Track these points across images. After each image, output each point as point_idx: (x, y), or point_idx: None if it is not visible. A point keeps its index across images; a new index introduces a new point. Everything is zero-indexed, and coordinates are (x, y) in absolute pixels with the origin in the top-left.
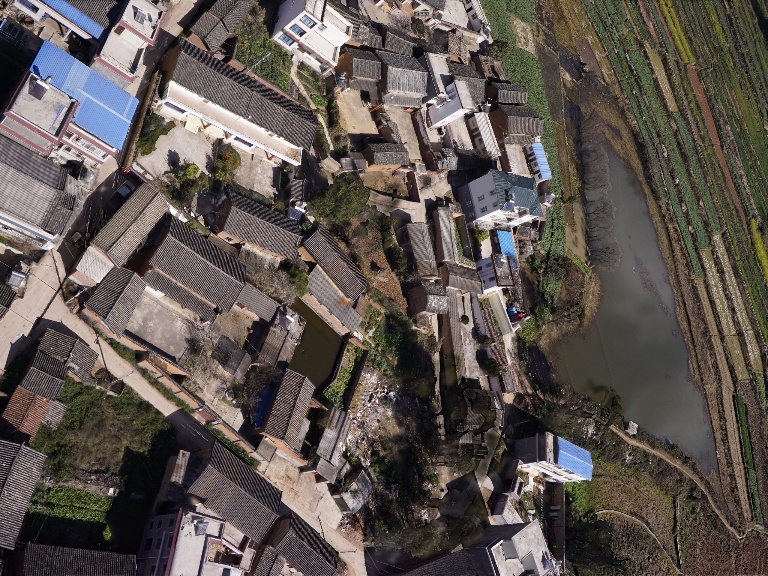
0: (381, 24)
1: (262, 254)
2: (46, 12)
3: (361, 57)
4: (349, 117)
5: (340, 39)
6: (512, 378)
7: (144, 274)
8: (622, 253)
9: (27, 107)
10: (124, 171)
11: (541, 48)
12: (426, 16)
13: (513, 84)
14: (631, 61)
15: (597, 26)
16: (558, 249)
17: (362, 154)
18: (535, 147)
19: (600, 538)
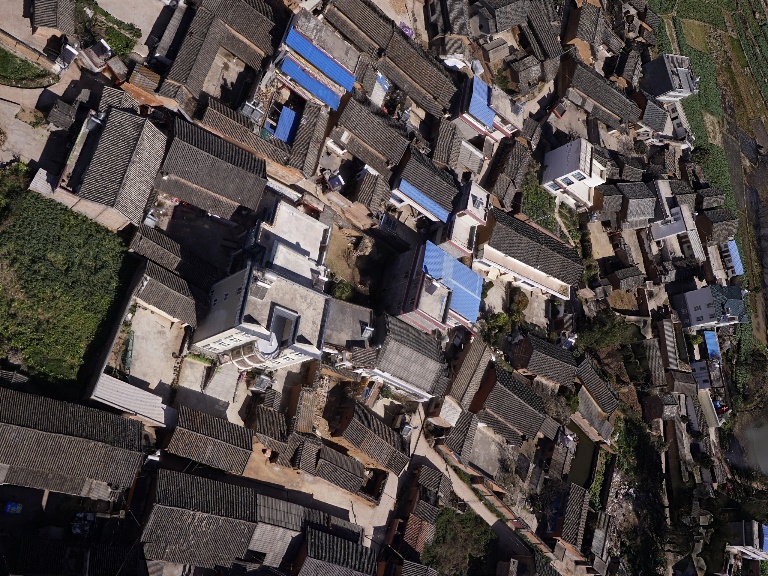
0: (618, 156)
1: (546, 382)
2: (410, 204)
3: (608, 193)
4: (594, 244)
5: (596, 182)
6: (721, 470)
7: (477, 413)
8: None
9: (425, 302)
10: None
11: (726, 138)
12: (647, 137)
13: (713, 188)
14: None
15: None
16: (747, 338)
17: (608, 279)
18: (730, 245)
19: None
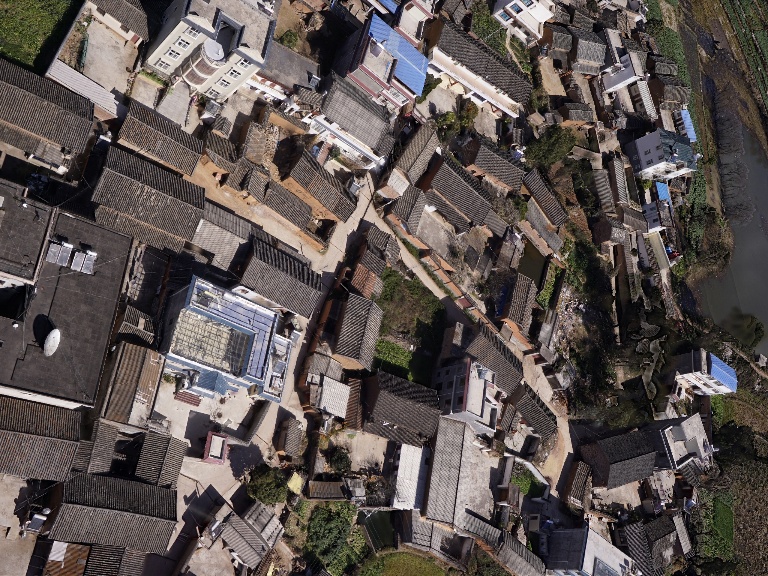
0: (569, 4)
1: (495, 185)
2: None
3: (558, 31)
4: (546, 81)
5: (545, 16)
6: (671, 303)
7: (425, 192)
8: (755, 209)
9: (370, 62)
10: (405, 115)
11: (682, 27)
12: None
13: (666, 58)
14: (757, 40)
15: (727, 8)
16: (700, 203)
17: (558, 111)
18: (683, 113)
19: (744, 439)
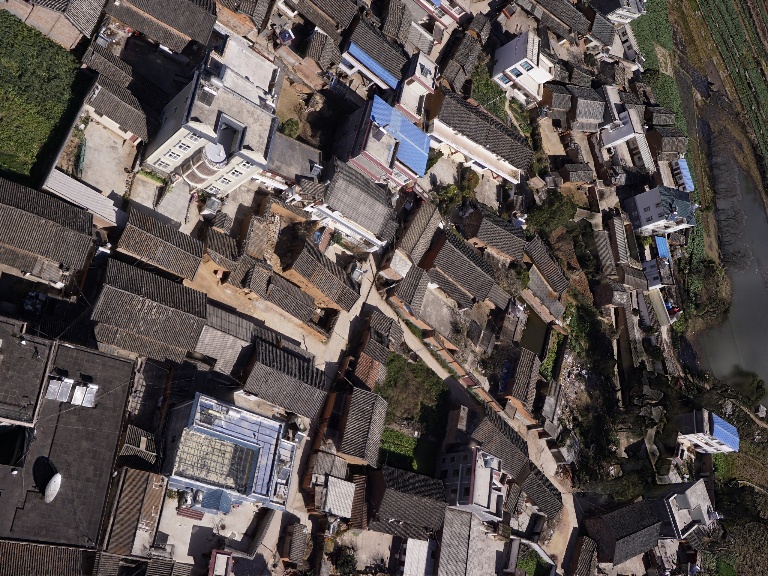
0: (568, 61)
1: (497, 256)
2: (360, 69)
3: (557, 92)
4: (545, 141)
5: (544, 78)
6: (672, 363)
7: (428, 271)
8: (753, 257)
9: (372, 147)
10: (406, 190)
11: (677, 71)
12: (596, 51)
13: (663, 107)
14: (750, 79)
15: (721, 47)
16: (699, 252)
17: (558, 173)
18: (680, 163)
19: (746, 500)
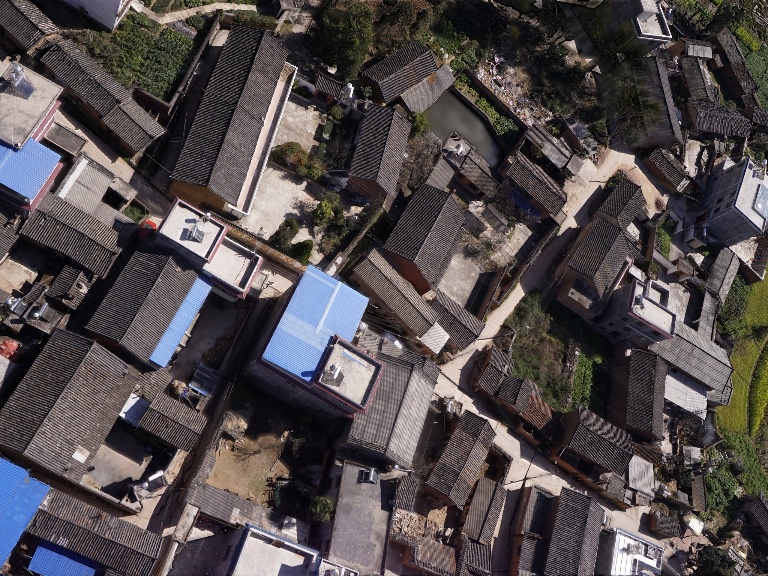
0: None
1: None
2: None
3: None
4: None
5: None
6: None
7: (431, 289)
8: None
9: (353, 390)
10: None
11: None
12: None
13: None
14: None
15: None
16: None
17: None
18: None
19: None
